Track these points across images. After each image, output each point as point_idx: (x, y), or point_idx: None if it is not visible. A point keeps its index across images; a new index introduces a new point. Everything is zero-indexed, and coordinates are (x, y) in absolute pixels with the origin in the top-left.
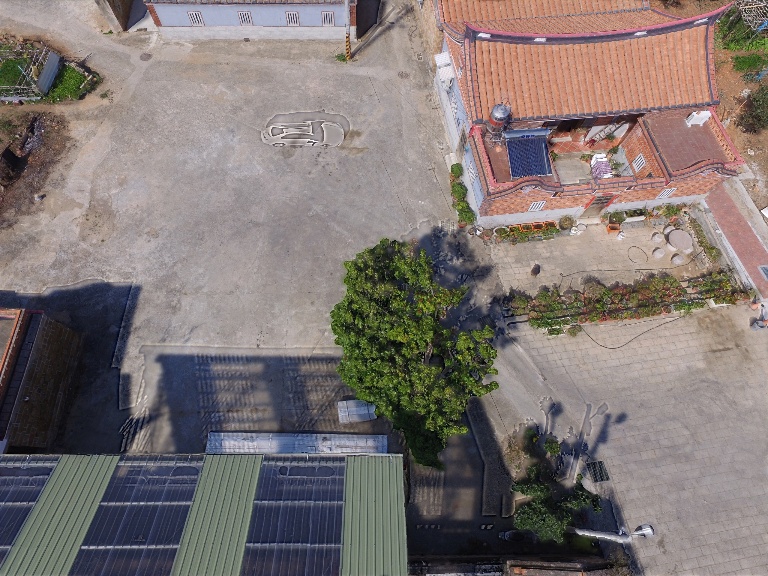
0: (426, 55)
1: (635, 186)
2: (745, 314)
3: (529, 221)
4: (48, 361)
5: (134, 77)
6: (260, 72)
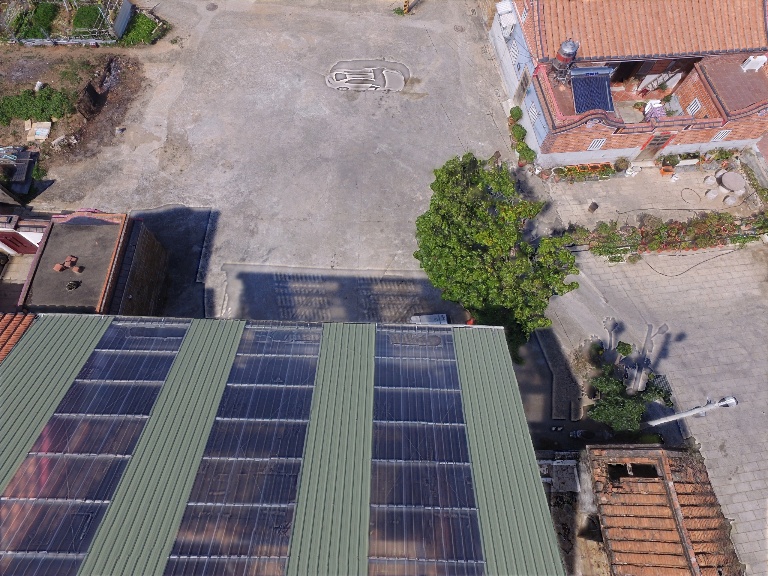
0: (480, 10)
1: (693, 125)
2: None
3: (586, 162)
4: (145, 268)
5: (201, 25)
6: (322, 23)
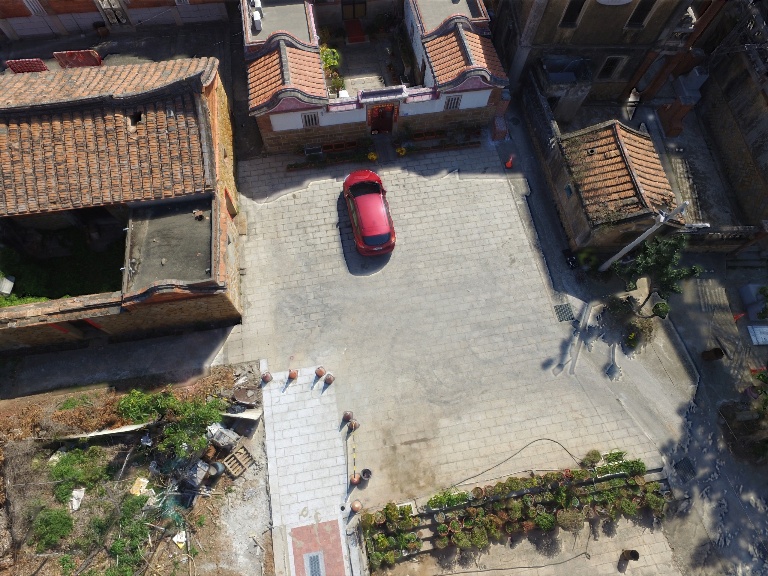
0: None
1: None
2: (371, 494)
3: None
4: None
5: None
6: None
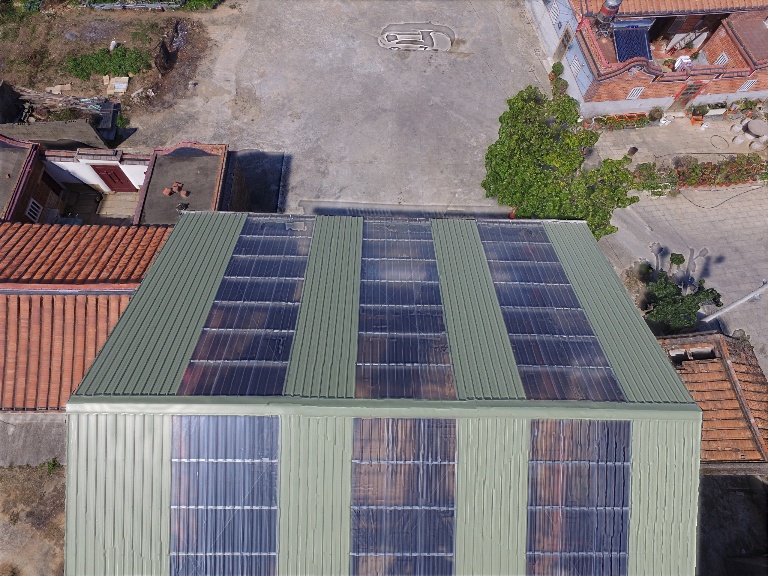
0: None
1: (724, 73)
2: None
3: (623, 112)
4: (237, 198)
5: None
6: None
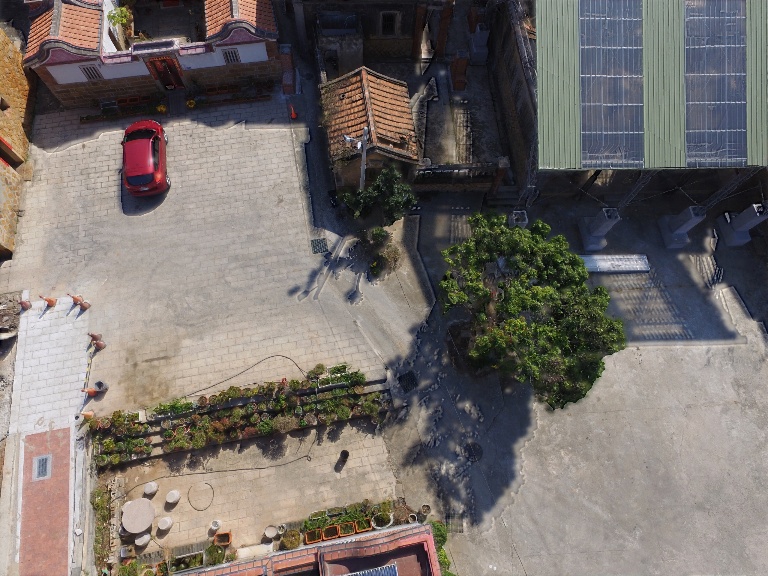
0: None
1: (203, 573)
2: (106, 405)
3: None
4: None
5: None
6: None
